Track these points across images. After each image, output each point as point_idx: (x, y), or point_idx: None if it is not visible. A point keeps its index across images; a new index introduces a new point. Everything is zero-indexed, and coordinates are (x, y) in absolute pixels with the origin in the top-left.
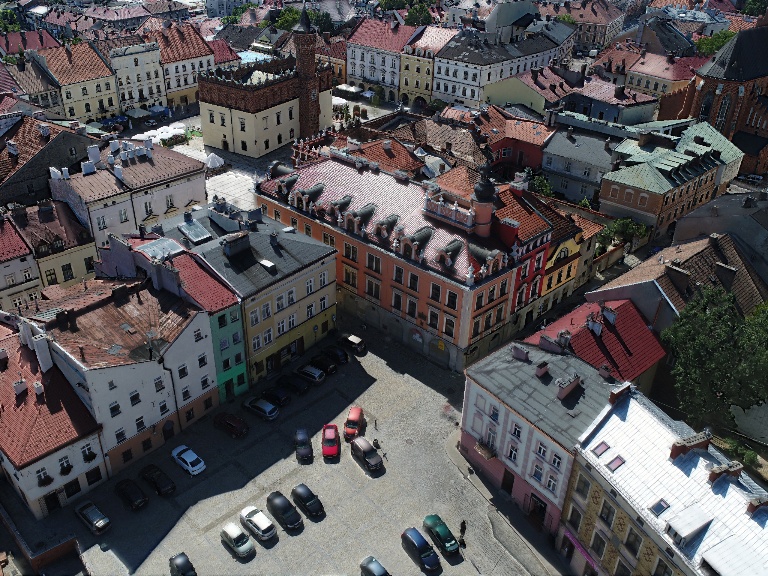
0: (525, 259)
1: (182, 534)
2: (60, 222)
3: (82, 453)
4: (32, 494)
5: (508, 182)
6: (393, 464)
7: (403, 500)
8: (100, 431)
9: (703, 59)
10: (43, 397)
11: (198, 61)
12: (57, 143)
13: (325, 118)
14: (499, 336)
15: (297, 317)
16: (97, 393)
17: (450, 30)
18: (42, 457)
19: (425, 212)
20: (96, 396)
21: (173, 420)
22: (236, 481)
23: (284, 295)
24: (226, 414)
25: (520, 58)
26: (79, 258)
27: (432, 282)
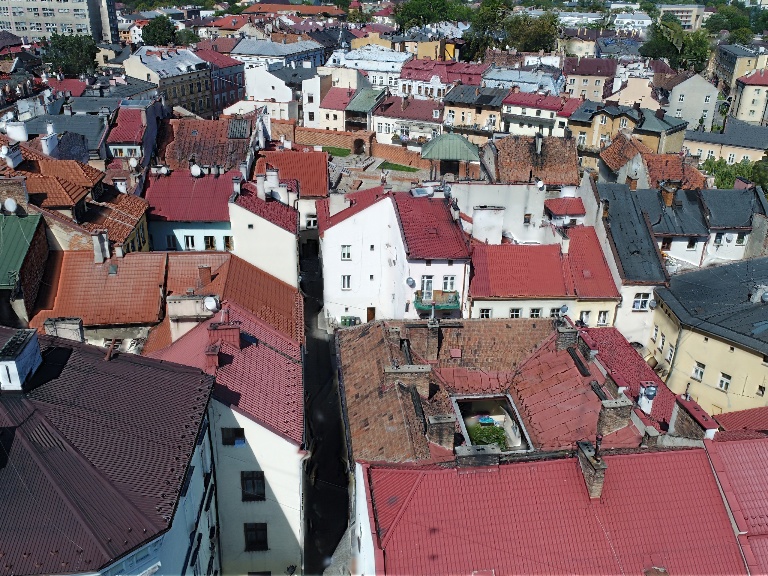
0: None
1: None
2: None
3: None
4: None
5: None
6: None
7: None
8: None
9: None
10: None
11: None
12: None
13: None
14: None
15: None
16: None
17: None
18: None
19: None
20: None
21: None
22: None
23: None
24: None
25: None
26: None
27: None
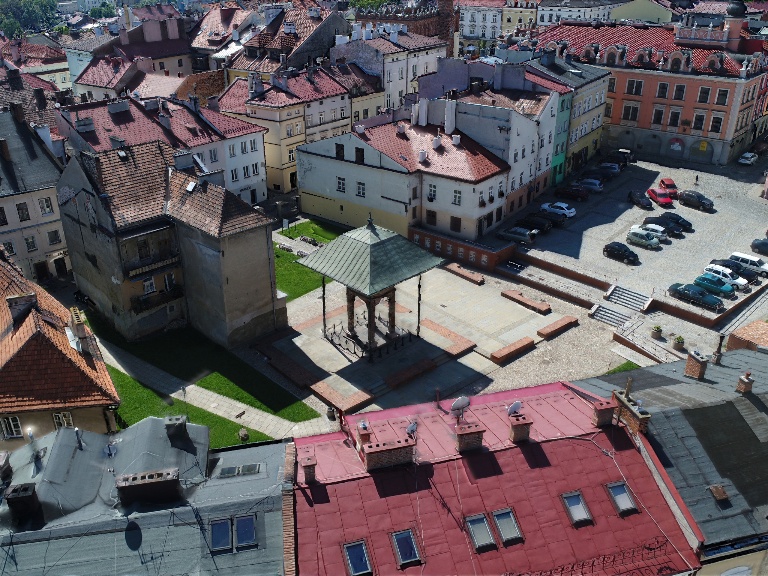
0: (766, 70)
1: (593, 242)
2: (356, 75)
3: (498, 189)
4: (475, 213)
5: None
6: (719, 207)
7: (745, 222)
8: None
9: (761, 4)
10: (462, 146)
11: None
12: (328, 22)
13: None
14: (743, 141)
15: (588, 125)
16: (513, 135)
17: None
18: (486, 178)
19: (677, 40)
20: (512, 137)
21: (532, 186)
22: (605, 219)
23: (587, 99)
24: (565, 187)
25: (610, 6)
26: (374, 105)
27: (701, 86)
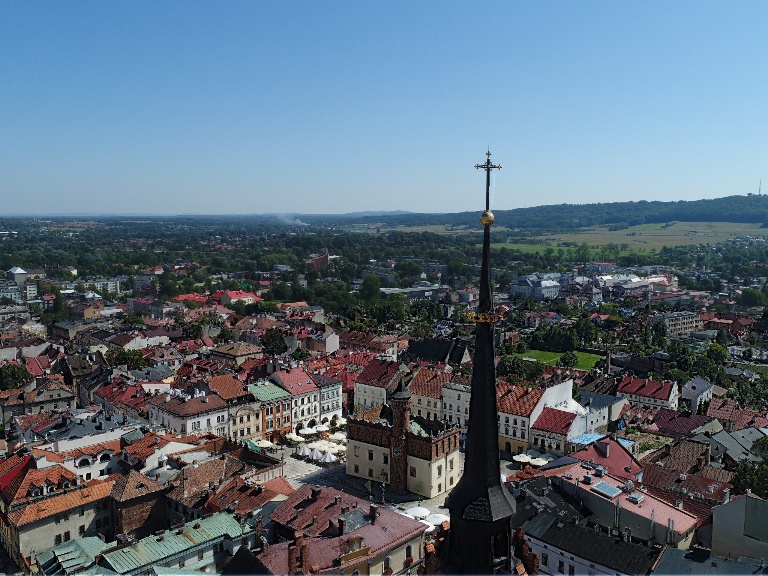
0: None
1: None
2: None
3: None
4: None
5: (52, 461)
6: None
7: None
8: None
9: None
10: None
11: (513, 418)
12: None
13: (423, 485)
14: None
15: None
16: None
17: None
18: None
19: None
20: None
21: None
22: None
23: None
24: None
25: None
26: None
27: None
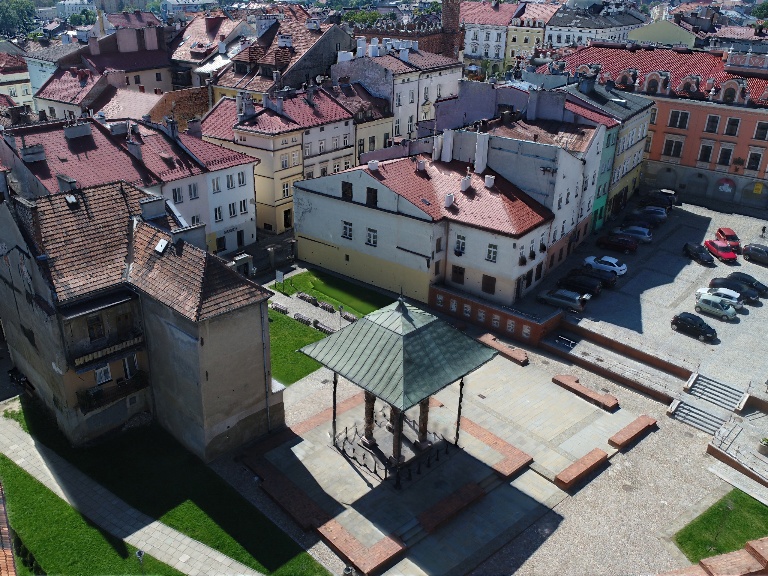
0: None
1: (655, 310)
2: (361, 97)
3: None
4: (514, 272)
5: None
6: None
7: None
8: (552, 221)
9: None
10: (496, 188)
11: None
12: (329, 36)
13: None
14: None
15: (630, 162)
16: (558, 177)
17: (551, 5)
18: (528, 231)
19: (728, 67)
20: (557, 180)
21: None
22: (662, 278)
23: (631, 133)
24: (609, 236)
25: (621, 27)
26: (382, 132)
27: (759, 121)
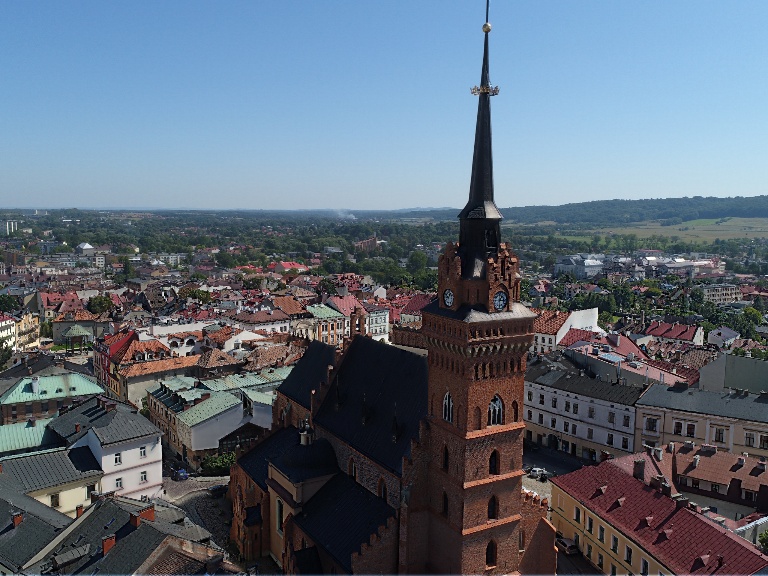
0: None
1: None
2: None
3: None
4: None
5: None
6: None
7: None
8: None
9: (646, 493)
10: None
11: None
12: None
13: None
14: None
15: None
16: None
17: None
18: None
19: None
20: None
21: None
22: None
23: None
24: None
25: None
26: None
27: None
